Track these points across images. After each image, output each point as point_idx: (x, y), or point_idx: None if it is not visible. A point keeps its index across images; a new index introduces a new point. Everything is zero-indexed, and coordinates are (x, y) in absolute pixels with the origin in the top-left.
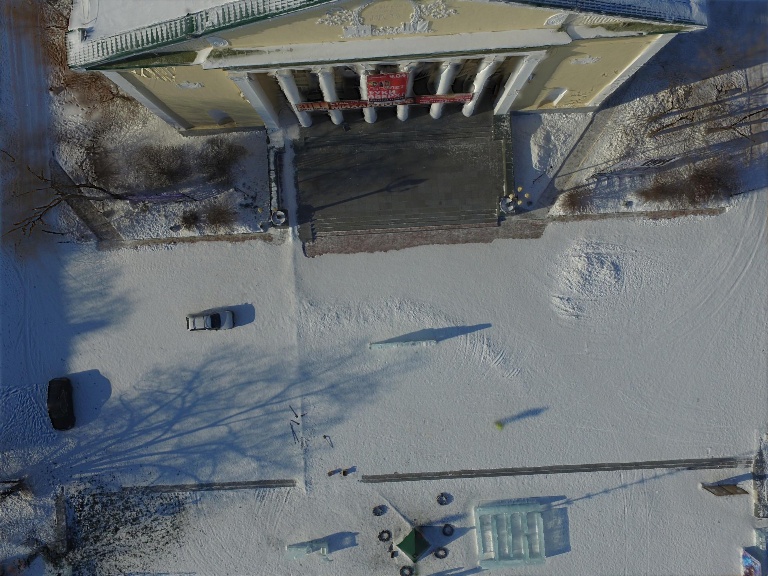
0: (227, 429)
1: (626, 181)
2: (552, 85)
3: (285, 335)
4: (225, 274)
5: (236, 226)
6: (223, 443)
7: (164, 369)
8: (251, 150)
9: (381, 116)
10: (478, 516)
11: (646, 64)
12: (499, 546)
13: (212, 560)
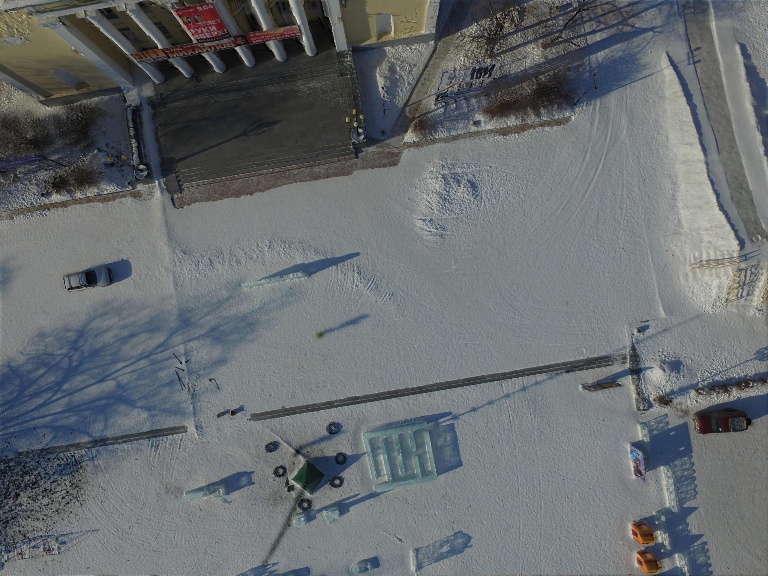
0: (115, 383)
1: (473, 102)
2: (374, 11)
3: (162, 286)
4: (100, 234)
5: (104, 186)
6: (112, 397)
7: (49, 332)
8: (112, 112)
9: (229, 65)
10: (365, 440)
11: None
12: (392, 469)
13: (113, 515)
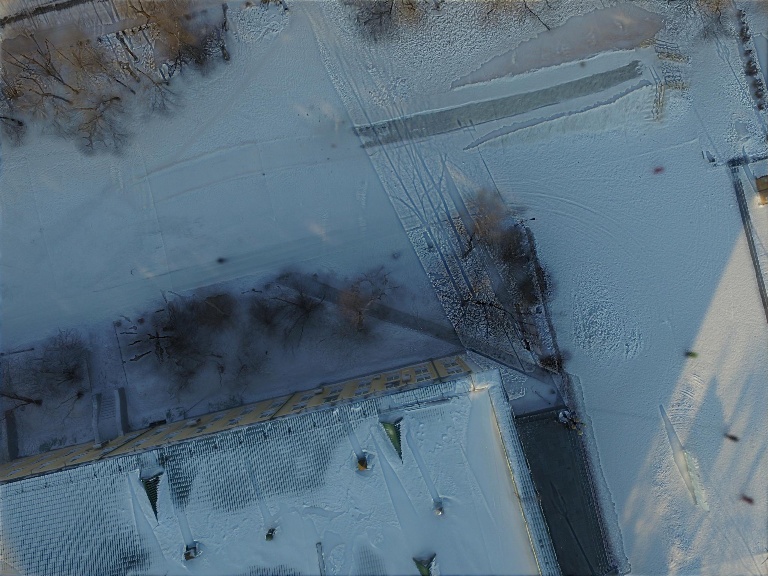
0: None
1: None
2: None
3: None
4: None
5: None
6: None
7: None
8: None
9: None
10: None
11: (417, 314)
12: None
13: None
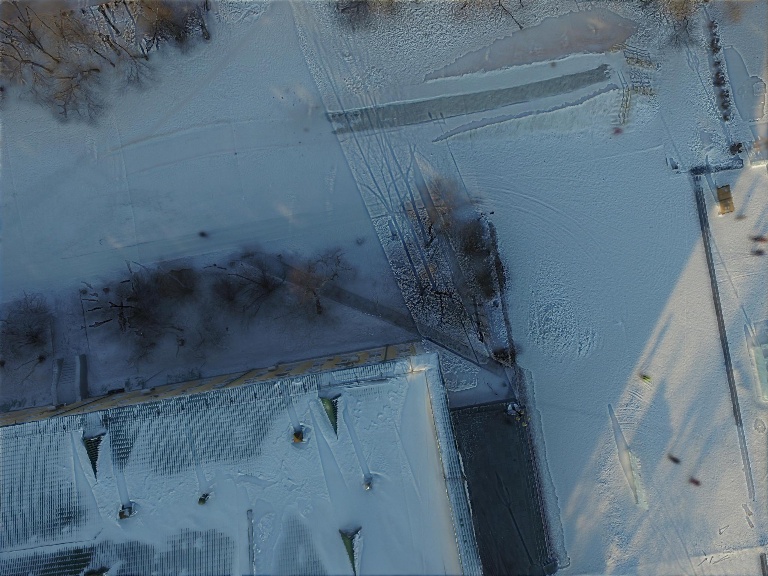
0: None
1: None
2: None
3: (638, 575)
4: None
5: None
6: None
7: None
8: None
9: None
10: None
11: (377, 300)
12: None
13: None
